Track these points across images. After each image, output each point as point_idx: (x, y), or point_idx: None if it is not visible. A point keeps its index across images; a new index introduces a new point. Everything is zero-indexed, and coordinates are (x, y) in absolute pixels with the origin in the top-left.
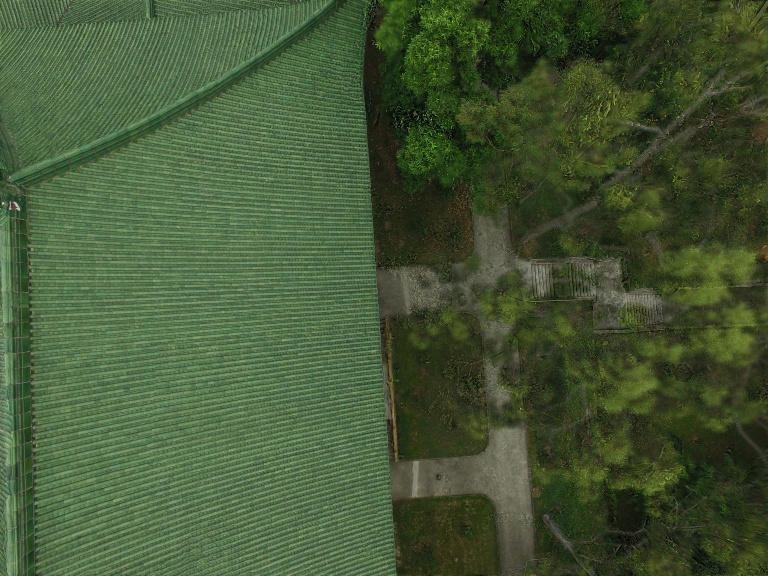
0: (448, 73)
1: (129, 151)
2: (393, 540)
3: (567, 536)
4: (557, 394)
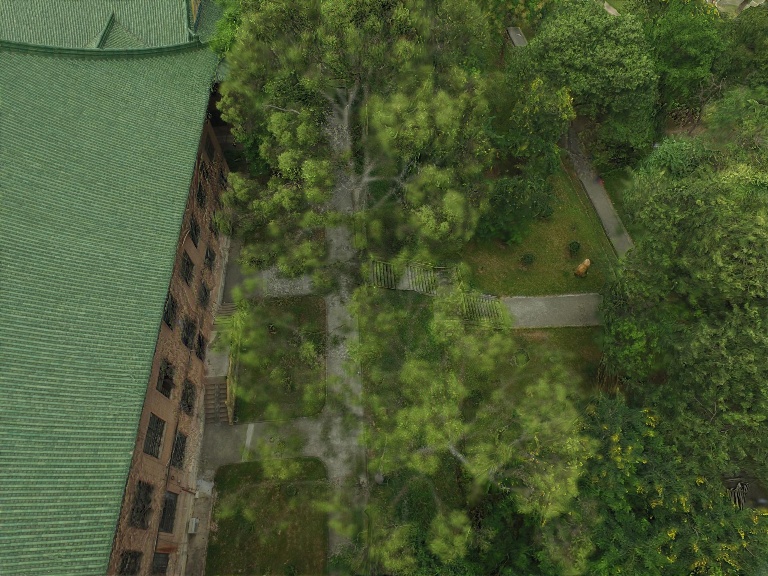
0: (315, 148)
1: (25, 58)
2: (154, 347)
3: (404, 503)
4: (395, 362)
